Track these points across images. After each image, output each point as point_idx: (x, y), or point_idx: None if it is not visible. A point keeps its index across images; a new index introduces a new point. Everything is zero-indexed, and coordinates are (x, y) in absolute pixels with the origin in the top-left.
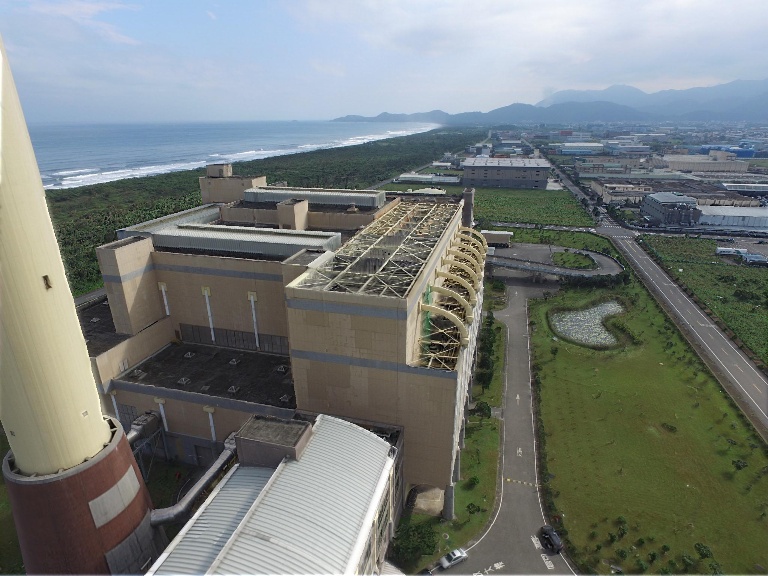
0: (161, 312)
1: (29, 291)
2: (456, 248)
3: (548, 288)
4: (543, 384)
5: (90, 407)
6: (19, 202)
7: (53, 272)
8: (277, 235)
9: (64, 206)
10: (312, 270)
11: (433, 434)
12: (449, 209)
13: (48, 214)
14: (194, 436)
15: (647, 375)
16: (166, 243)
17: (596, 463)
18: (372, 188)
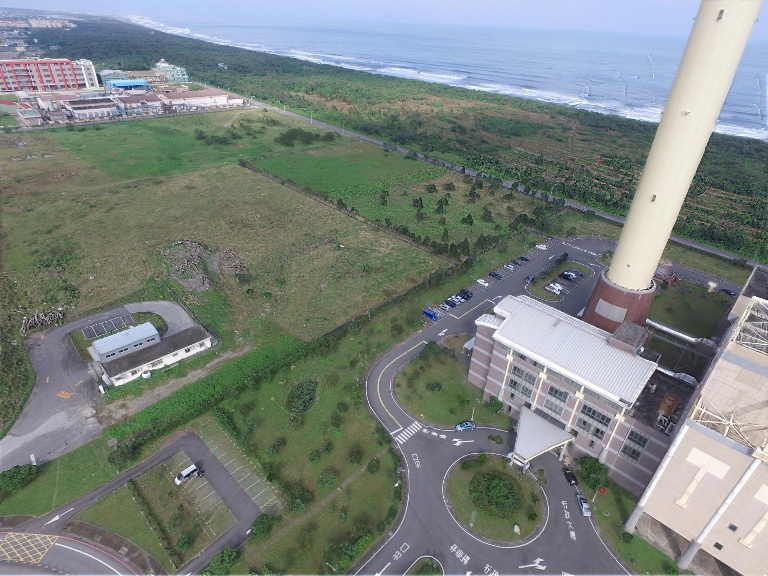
0: None
1: (645, 197)
2: None
3: None
4: None
5: (633, 266)
6: (667, 159)
7: (661, 196)
8: None
9: None
10: None
11: None
12: None
13: (685, 171)
14: None
15: None
16: None
17: None
18: None
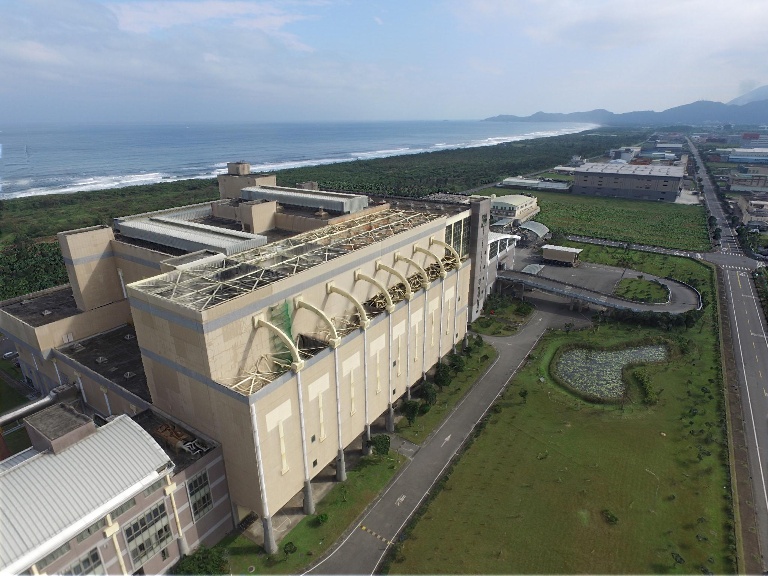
0: (121, 295)
1: None
2: (427, 262)
3: (584, 319)
4: (485, 429)
5: None
6: None
7: None
8: (213, 234)
9: (191, 194)
10: (175, 271)
11: (243, 458)
12: (425, 219)
13: None
14: (100, 411)
15: (631, 445)
16: (127, 233)
17: (477, 536)
18: (469, 191)
